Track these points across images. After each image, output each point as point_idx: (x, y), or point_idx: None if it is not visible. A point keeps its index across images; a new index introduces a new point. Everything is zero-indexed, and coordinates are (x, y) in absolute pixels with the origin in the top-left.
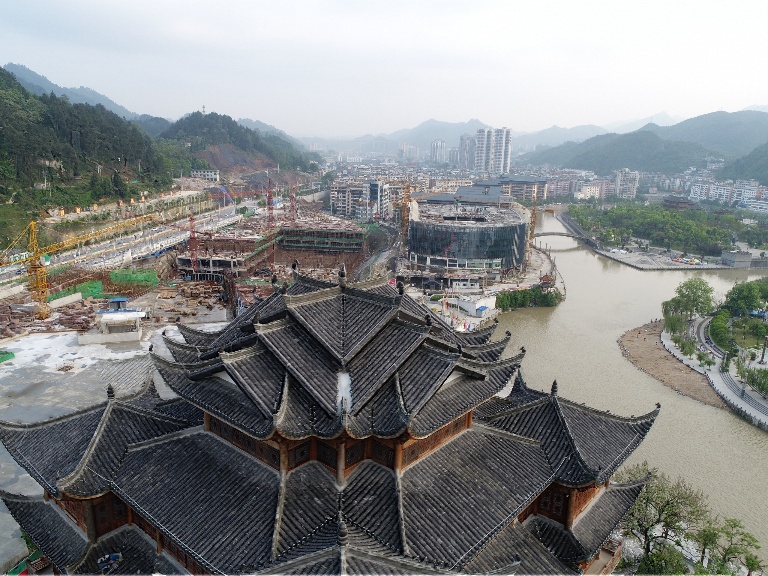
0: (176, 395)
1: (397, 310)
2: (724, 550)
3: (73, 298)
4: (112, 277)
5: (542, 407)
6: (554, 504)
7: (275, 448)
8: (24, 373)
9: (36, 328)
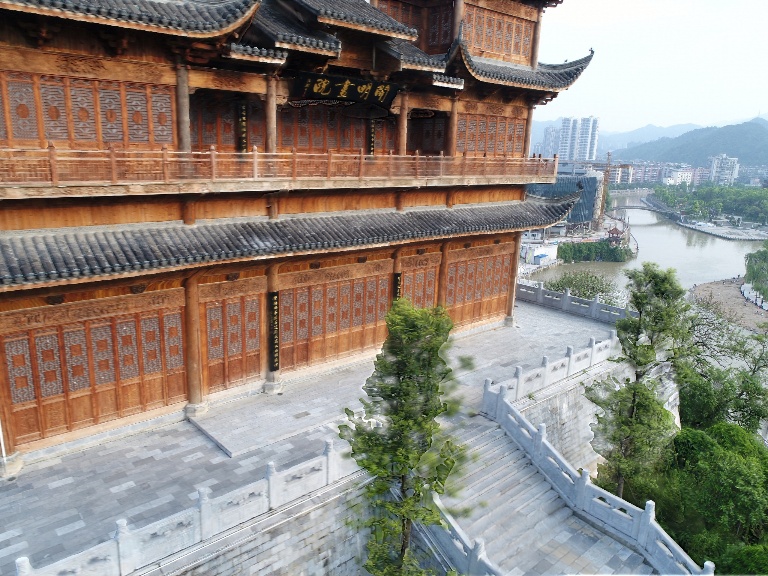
0: None
1: None
2: (754, 359)
3: None
4: None
5: None
6: (442, 29)
7: None
8: None
9: None
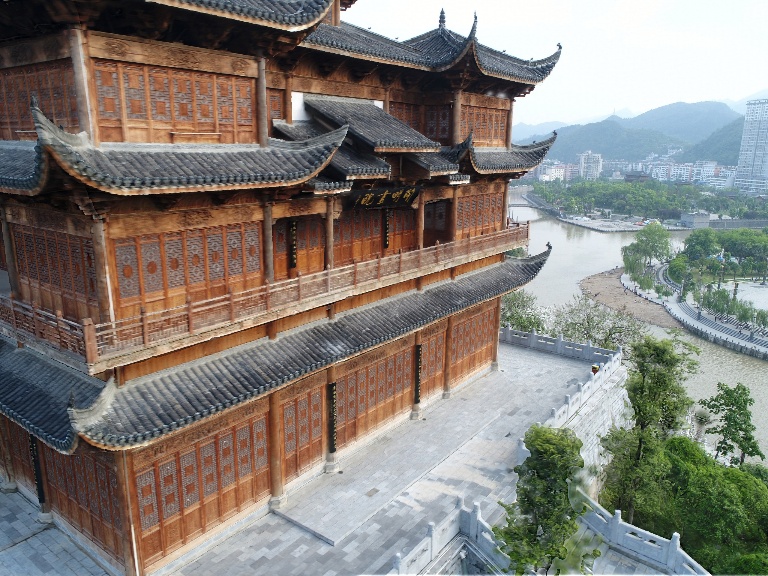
0: None
1: None
2: None
3: None
4: None
5: (429, 39)
6: (440, 125)
7: None
8: None
9: None
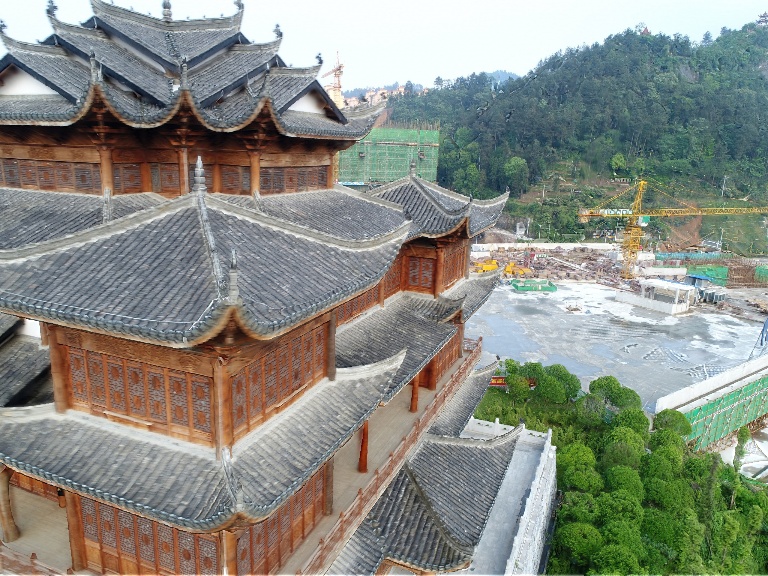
0: (614, 358)
1: (93, 16)
2: None
3: (675, 271)
4: (757, 271)
5: None
6: None
7: None
8: (543, 301)
9: (607, 281)
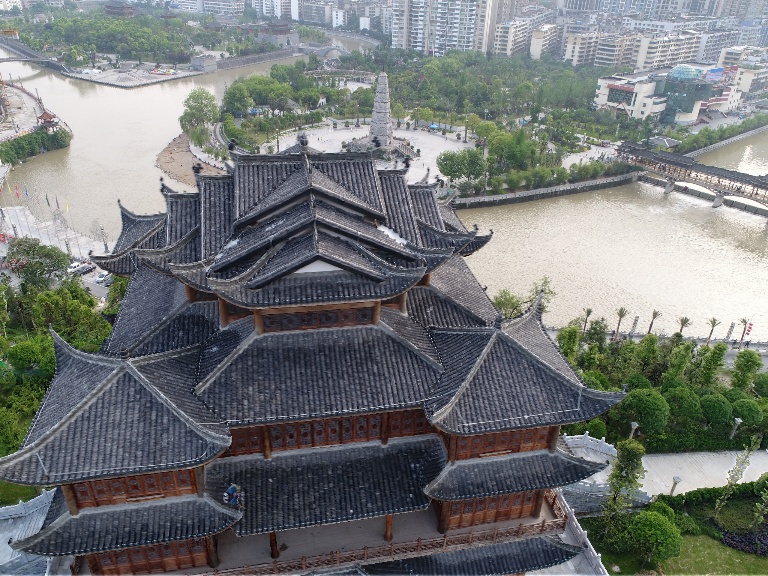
0: None
1: None
2: None
3: None
4: None
5: None
6: None
7: (368, 307)
8: None
9: None
